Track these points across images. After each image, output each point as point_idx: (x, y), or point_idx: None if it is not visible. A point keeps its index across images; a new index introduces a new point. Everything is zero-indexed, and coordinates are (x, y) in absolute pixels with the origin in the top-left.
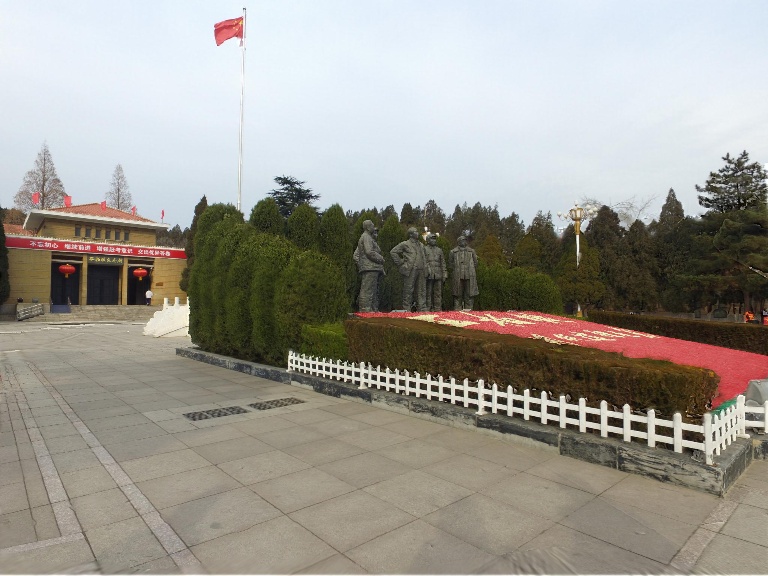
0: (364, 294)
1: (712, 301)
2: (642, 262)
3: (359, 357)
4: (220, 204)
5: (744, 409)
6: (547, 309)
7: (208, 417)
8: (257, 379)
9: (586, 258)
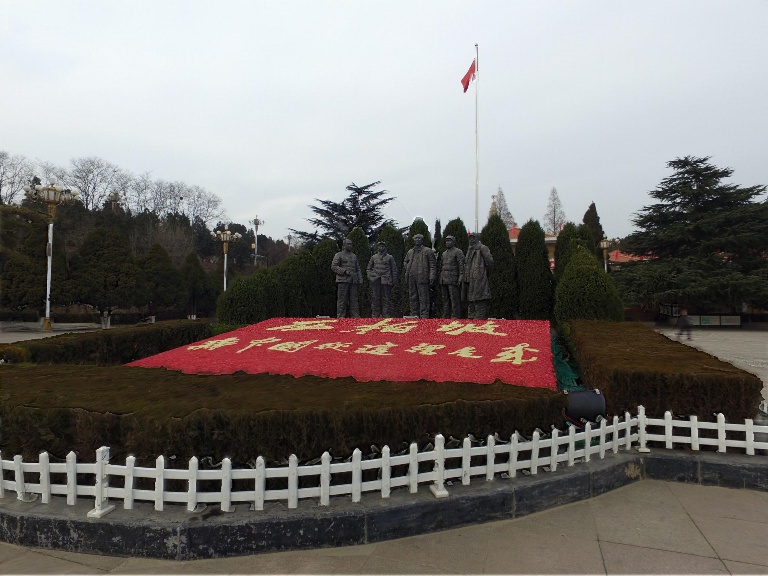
0: None
1: None
2: None
3: None
4: None
5: None
6: (567, 317)
7: None
8: None
9: None
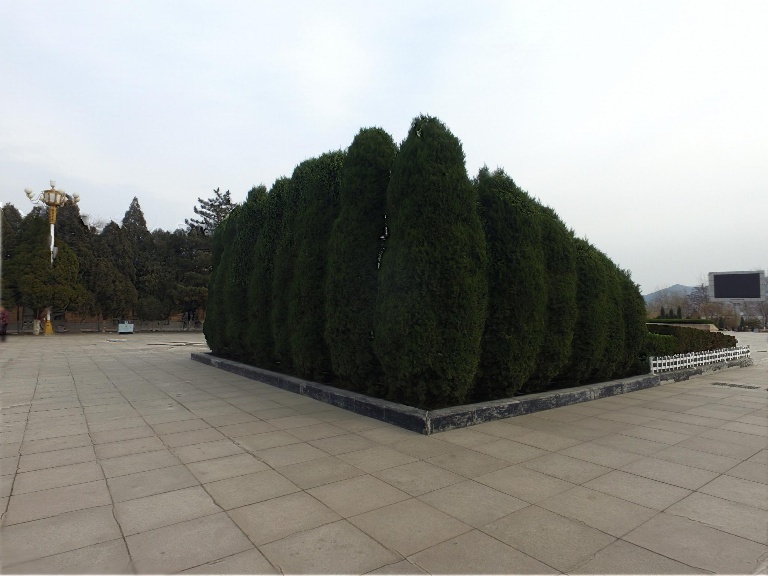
0: None
1: (183, 310)
2: (124, 268)
3: (682, 350)
4: None
5: None
6: None
7: None
8: (649, 391)
9: (65, 255)
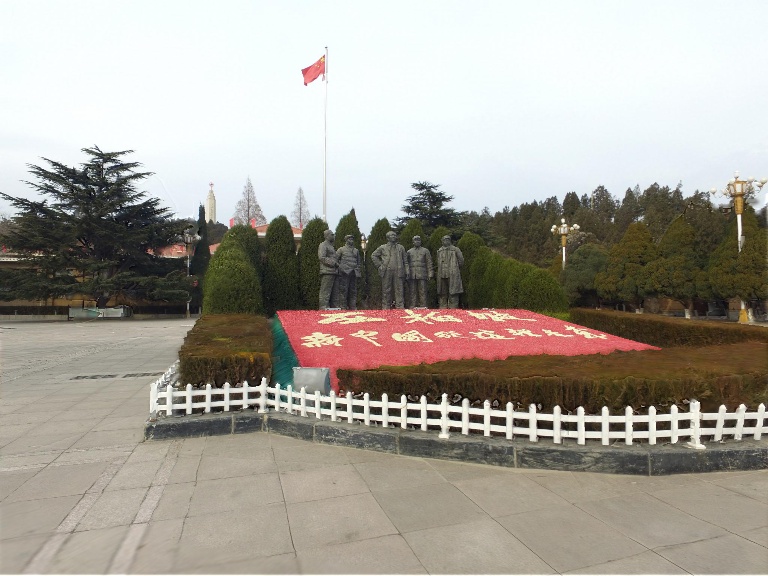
0: (321, 295)
1: None
2: None
3: None
4: (239, 225)
5: (266, 389)
6: (539, 307)
7: (82, 378)
8: None
9: (751, 242)
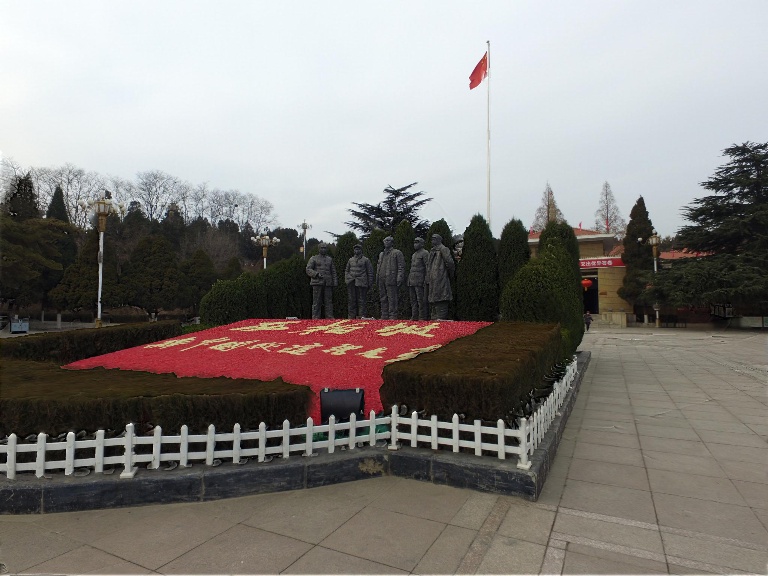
0: None
1: None
2: None
3: None
4: None
5: None
6: (509, 319)
7: None
8: None
9: None
